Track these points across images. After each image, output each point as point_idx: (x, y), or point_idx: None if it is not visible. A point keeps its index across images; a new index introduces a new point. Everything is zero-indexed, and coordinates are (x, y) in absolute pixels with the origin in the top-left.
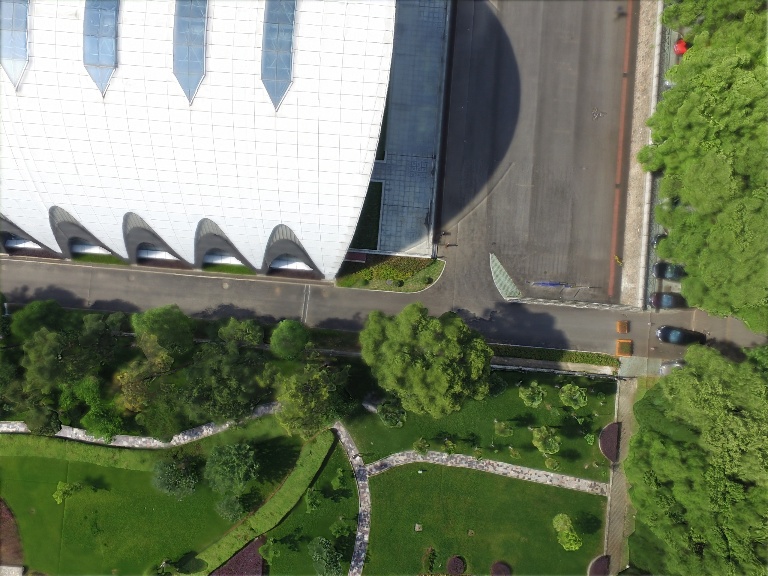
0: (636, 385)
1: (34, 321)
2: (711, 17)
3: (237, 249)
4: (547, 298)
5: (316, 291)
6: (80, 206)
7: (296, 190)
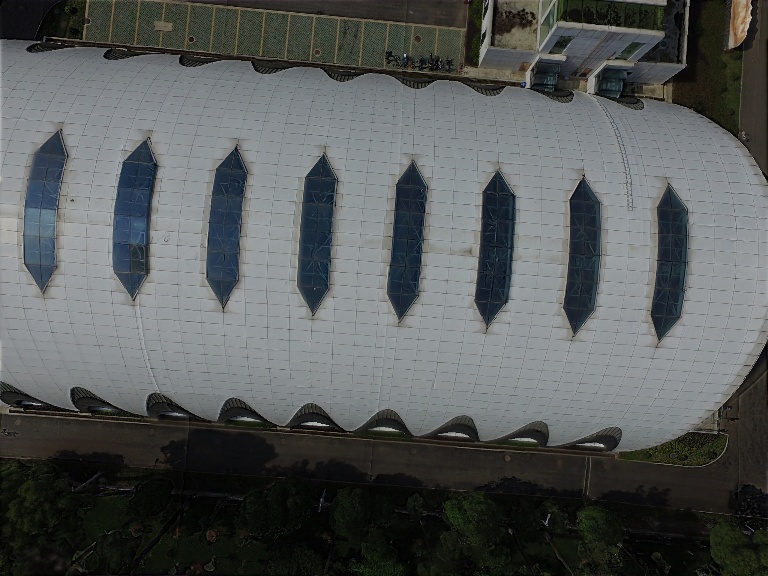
0: None
1: (360, 522)
2: None
3: (548, 438)
4: None
5: (597, 463)
6: (415, 410)
7: (649, 404)
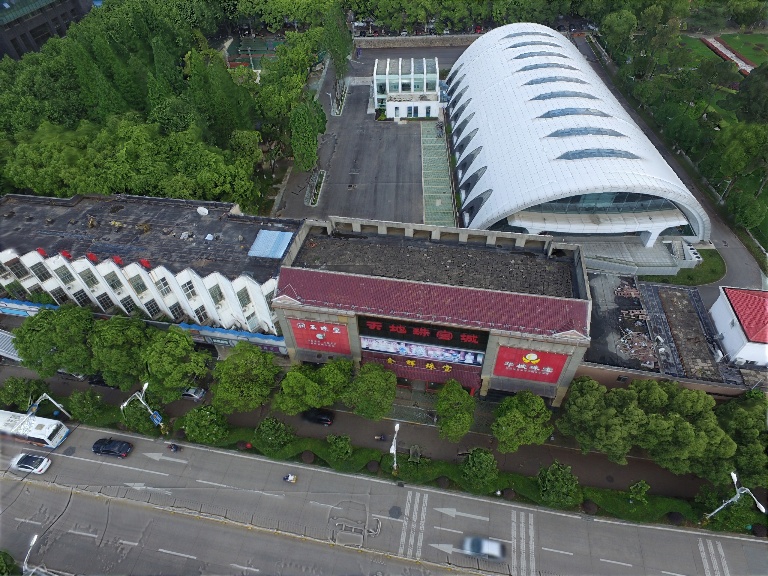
0: None
1: None
2: (487, 7)
3: None
4: None
5: None
6: None
7: None
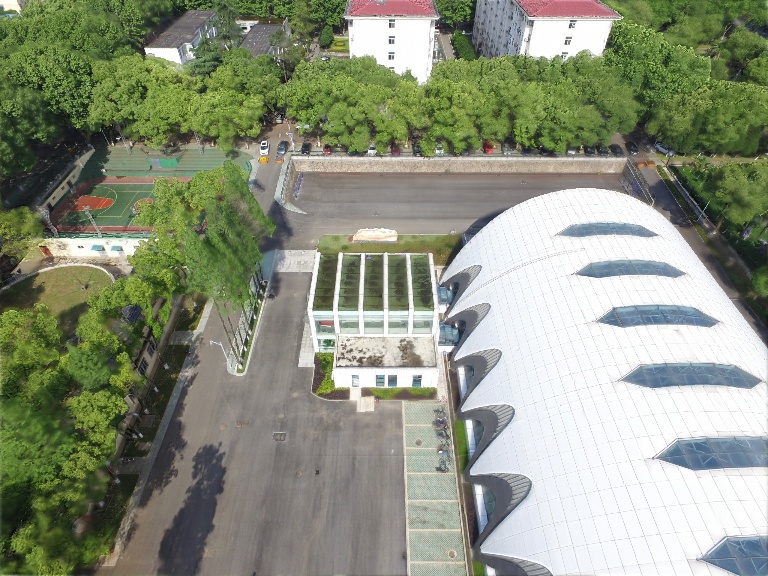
0: (665, 160)
1: None
2: (507, 121)
3: None
4: (637, 195)
5: None
6: None
7: None
